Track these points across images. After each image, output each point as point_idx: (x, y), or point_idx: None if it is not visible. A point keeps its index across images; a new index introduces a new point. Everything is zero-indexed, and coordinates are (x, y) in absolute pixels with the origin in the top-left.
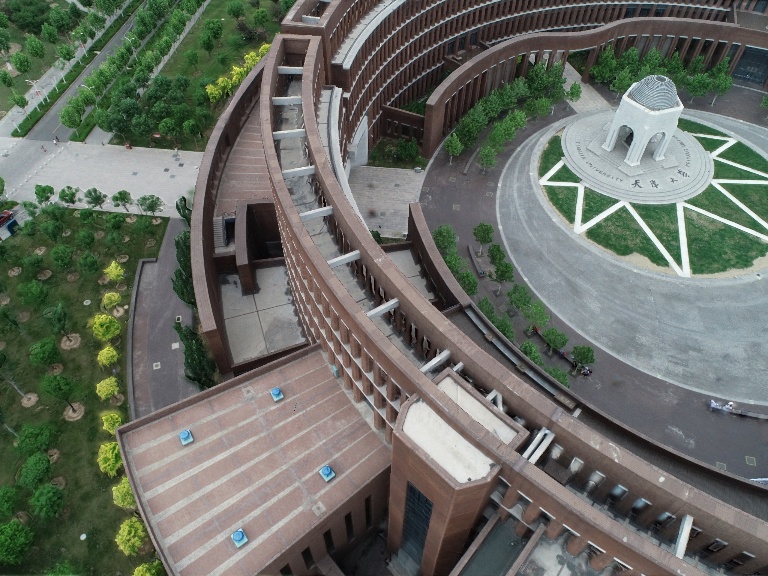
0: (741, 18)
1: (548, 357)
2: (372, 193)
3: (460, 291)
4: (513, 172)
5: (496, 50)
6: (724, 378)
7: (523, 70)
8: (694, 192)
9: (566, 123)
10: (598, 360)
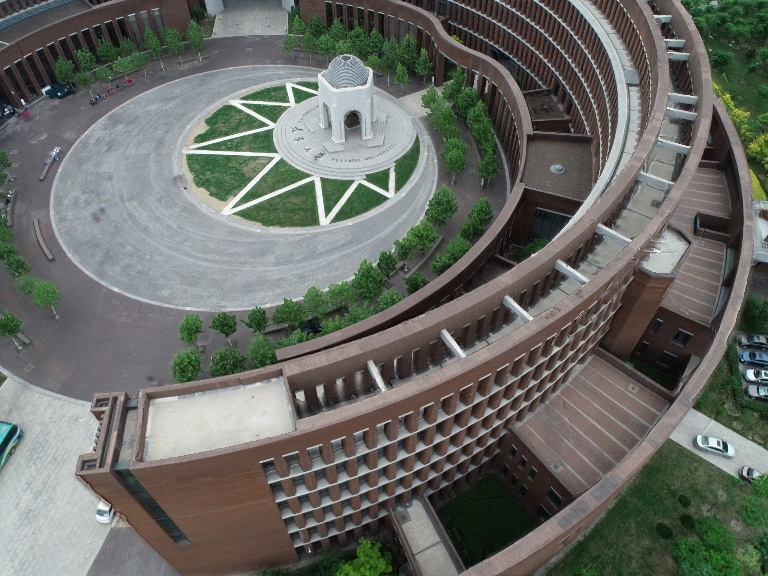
0: (570, 147)
1: (108, 90)
2: (259, 19)
3: (103, 5)
4: (298, 70)
5: (392, 1)
6: (82, 160)
7: (423, 47)
8: (295, 163)
9: (378, 93)
10: (104, 108)
